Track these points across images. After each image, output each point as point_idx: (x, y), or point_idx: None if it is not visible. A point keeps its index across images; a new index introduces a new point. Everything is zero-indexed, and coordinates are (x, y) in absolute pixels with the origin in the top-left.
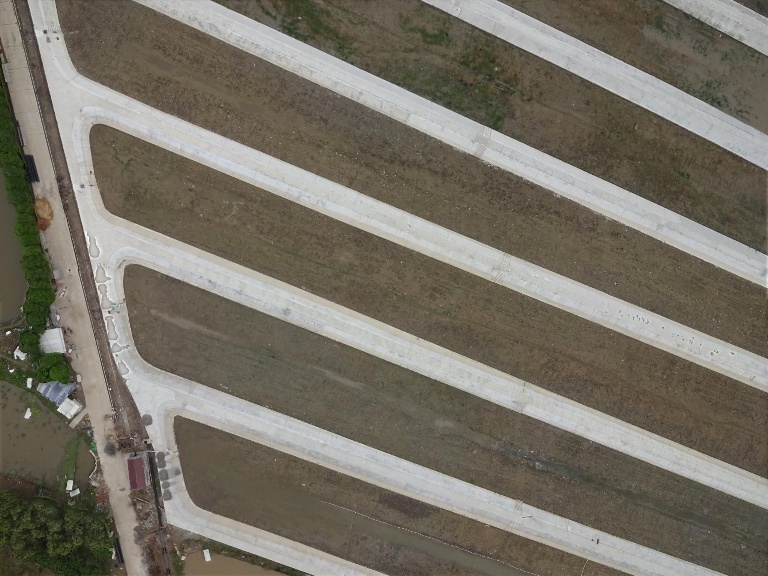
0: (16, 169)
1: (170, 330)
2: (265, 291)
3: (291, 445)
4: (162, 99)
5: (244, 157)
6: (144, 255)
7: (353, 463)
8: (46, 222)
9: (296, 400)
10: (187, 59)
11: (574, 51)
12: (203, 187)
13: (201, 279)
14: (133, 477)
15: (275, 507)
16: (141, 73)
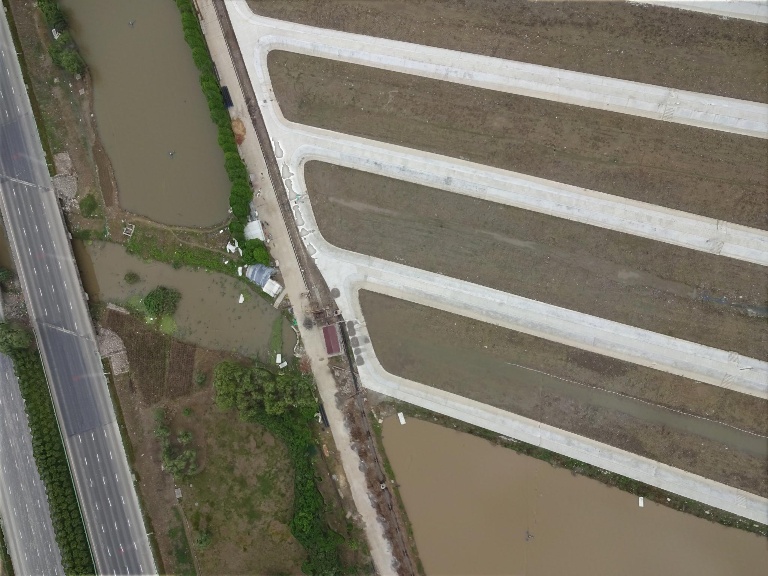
0: (215, 93)
1: (347, 213)
2: (426, 164)
3: (468, 307)
4: (320, 18)
5: (393, 49)
6: (318, 150)
7: (533, 320)
8: (241, 137)
9: (468, 265)
10: None
11: None
12: (361, 84)
13: (368, 163)
14: (329, 343)
15: (461, 370)
16: (301, 1)
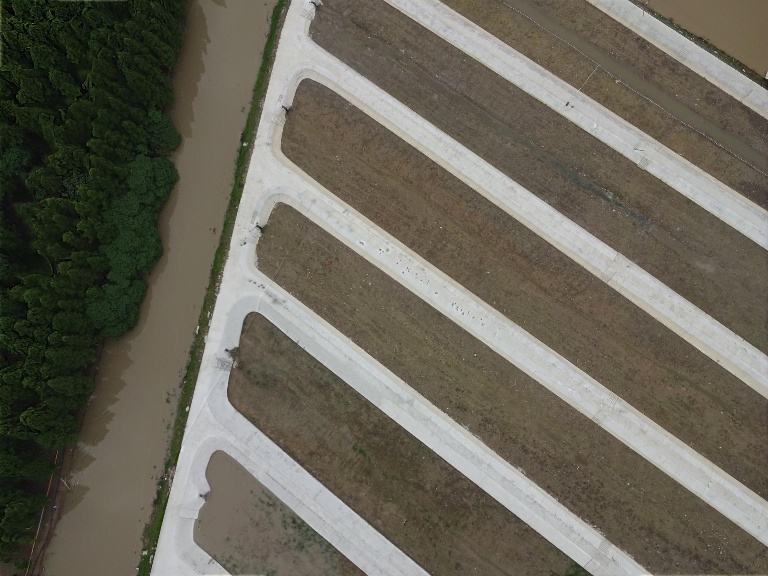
0: None
1: None
2: None
3: None
4: None
5: None
6: None
7: None
8: None
9: None
10: None
11: None
12: None
13: None
14: None
15: None
16: None
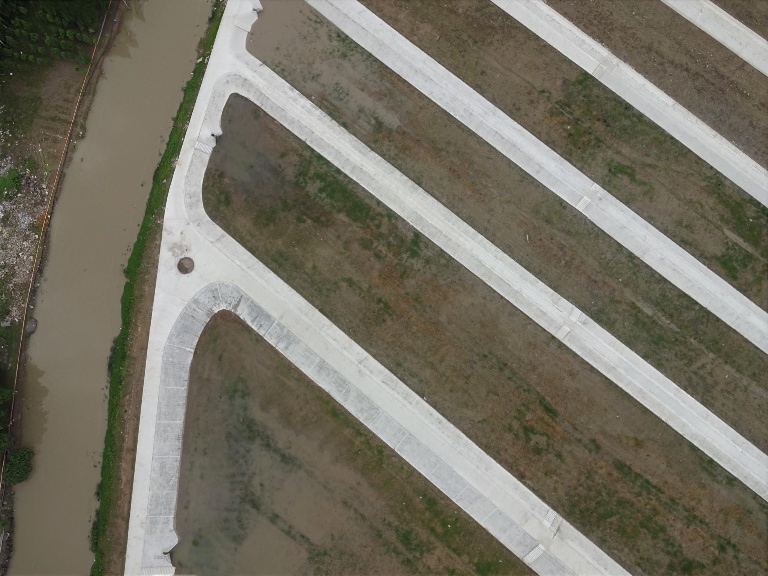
0: None
1: None
2: None
3: None
4: None
5: None
6: None
7: None
8: None
9: None
10: None
11: (487, 119)
12: None
13: None
14: None
15: None
16: None
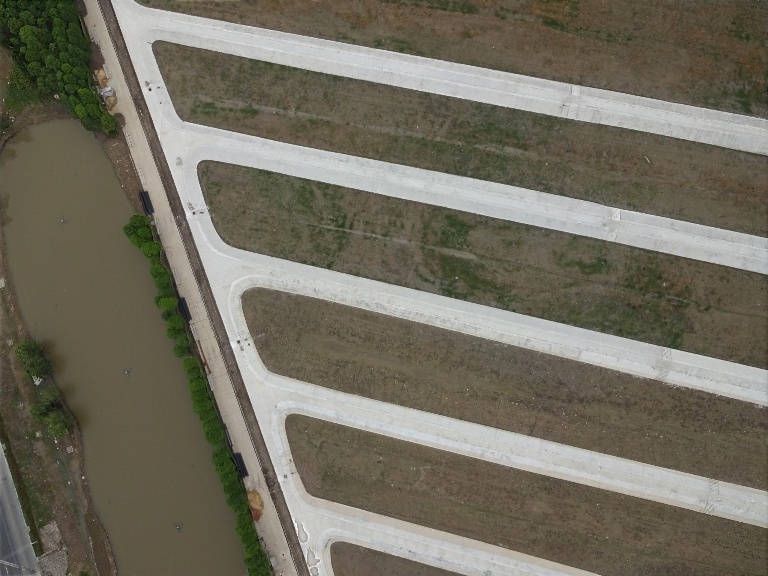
0: (231, 476)
1: None
2: (464, 555)
3: None
4: (343, 381)
5: (425, 424)
6: (347, 534)
7: None
8: (258, 512)
9: None
10: (360, 339)
11: (749, 250)
12: (390, 457)
13: (401, 550)
14: None
15: None
16: (321, 360)
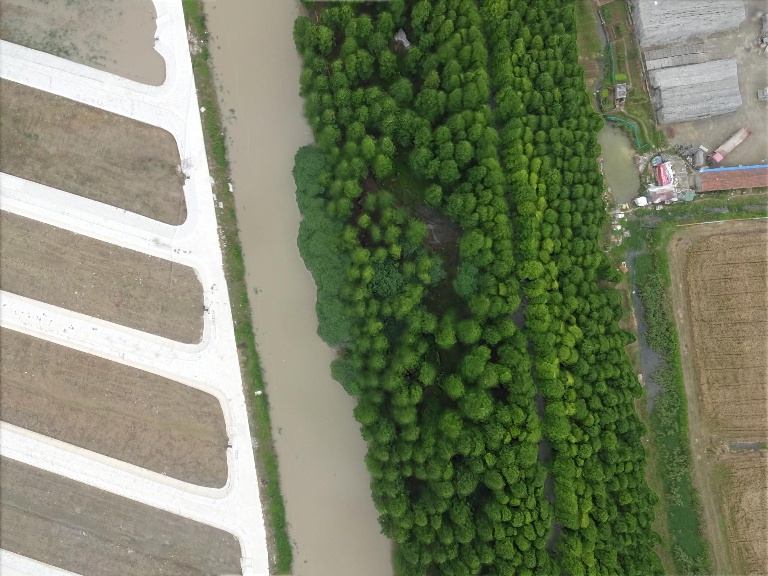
0: None
1: None
2: None
3: None
4: None
5: None
6: None
7: None
8: None
9: None
10: None
11: None
12: None
13: None
14: None
15: None
16: None
